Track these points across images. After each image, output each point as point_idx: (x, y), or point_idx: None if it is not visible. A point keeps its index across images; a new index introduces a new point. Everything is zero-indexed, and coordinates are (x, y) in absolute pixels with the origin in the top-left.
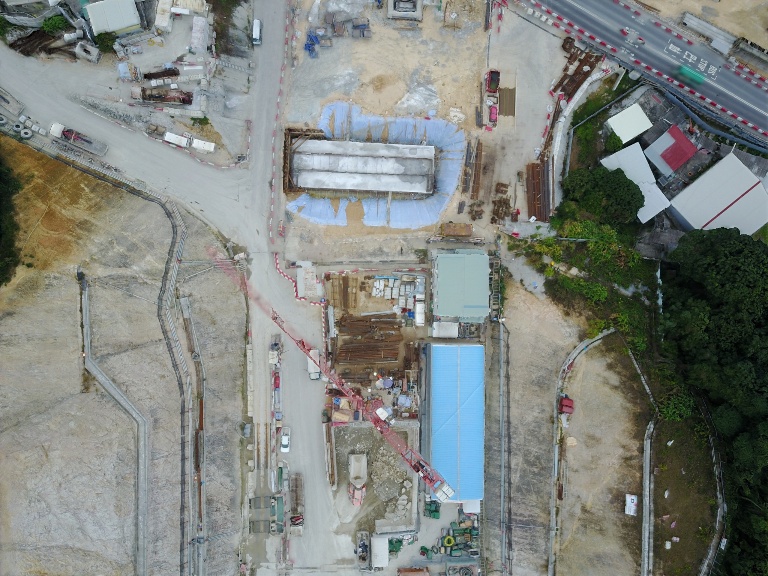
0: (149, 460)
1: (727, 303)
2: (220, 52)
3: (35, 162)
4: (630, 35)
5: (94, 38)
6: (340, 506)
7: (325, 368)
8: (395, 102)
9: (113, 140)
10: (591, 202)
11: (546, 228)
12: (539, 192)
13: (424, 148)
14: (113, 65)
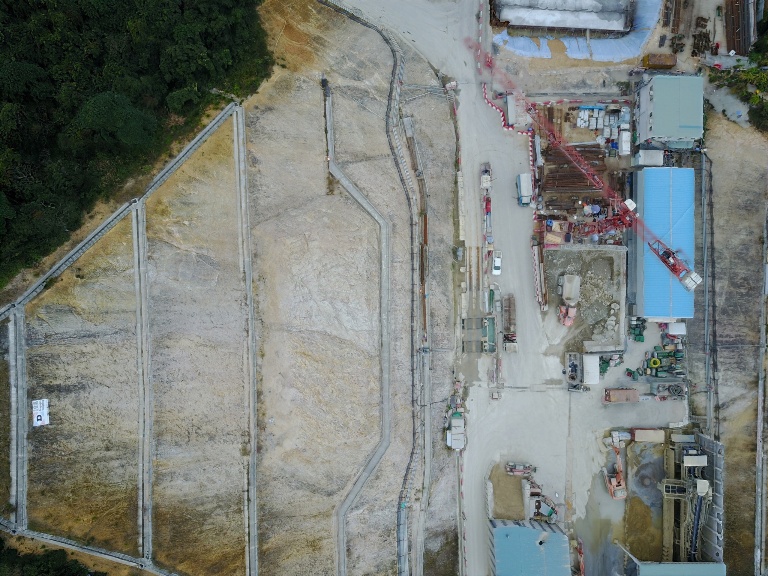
0: (390, 261)
1: None
2: None
3: None
4: None
5: None
6: (548, 328)
7: (533, 195)
8: None
9: None
10: None
11: (746, 61)
12: (738, 26)
13: None
14: None
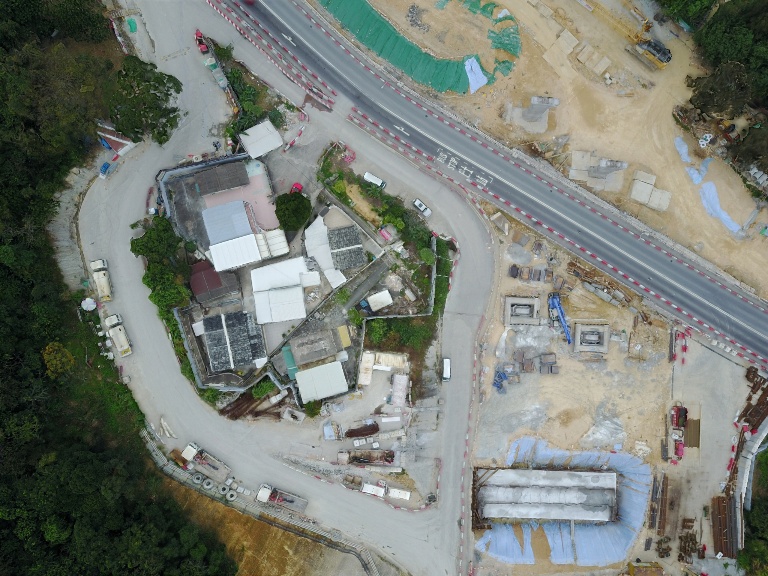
0: None
1: None
2: (415, 399)
3: (242, 529)
4: None
5: (301, 404)
6: None
7: None
8: (581, 436)
9: (311, 492)
10: None
11: (734, 566)
12: (725, 527)
13: (606, 476)
14: (315, 421)
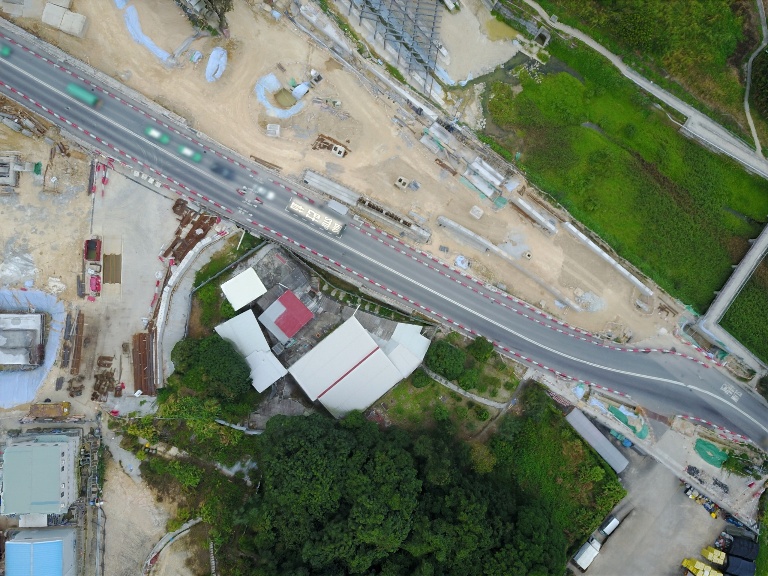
0: None
1: (285, 504)
2: None
3: None
4: (248, 195)
5: None
6: None
7: None
8: None
9: None
10: (191, 378)
11: (150, 403)
12: (146, 364)
13: (28, 317)
14: None
